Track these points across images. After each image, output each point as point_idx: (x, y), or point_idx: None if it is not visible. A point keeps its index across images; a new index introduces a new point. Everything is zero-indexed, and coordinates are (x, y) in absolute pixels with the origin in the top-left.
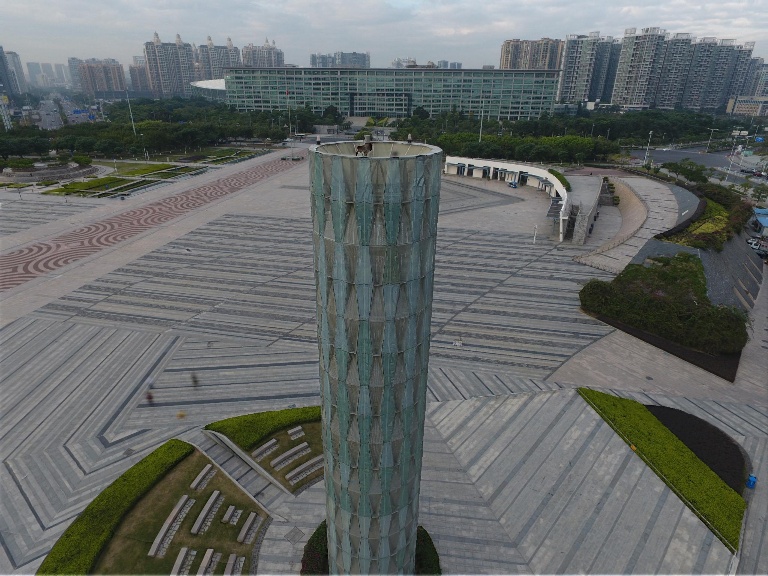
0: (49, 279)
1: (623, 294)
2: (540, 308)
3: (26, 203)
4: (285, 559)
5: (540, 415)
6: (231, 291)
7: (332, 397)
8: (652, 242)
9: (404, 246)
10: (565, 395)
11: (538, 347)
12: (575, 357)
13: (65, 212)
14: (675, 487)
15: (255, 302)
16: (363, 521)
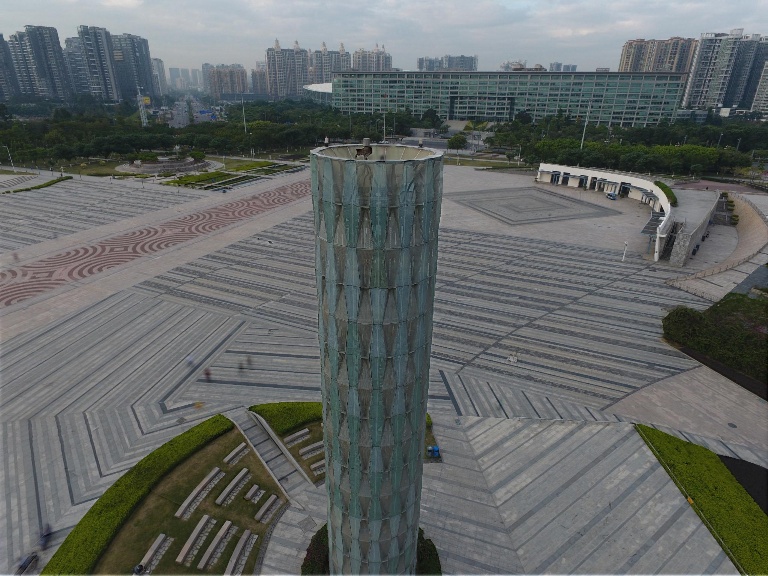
0: (150, 259)
1: (716, 326)
2: (614, 332)
3: (146, 191)
4: (294, 545)
5: (586, 447)
6: (300, 284)
7: (327, 394)
8: (763, 270)
9: (392, 251)
10: (620, 430)
11: (602, 374)
12: (644, 390)
13: (175, 201)
14: (733, 554)
15: None
16: (354, 521)
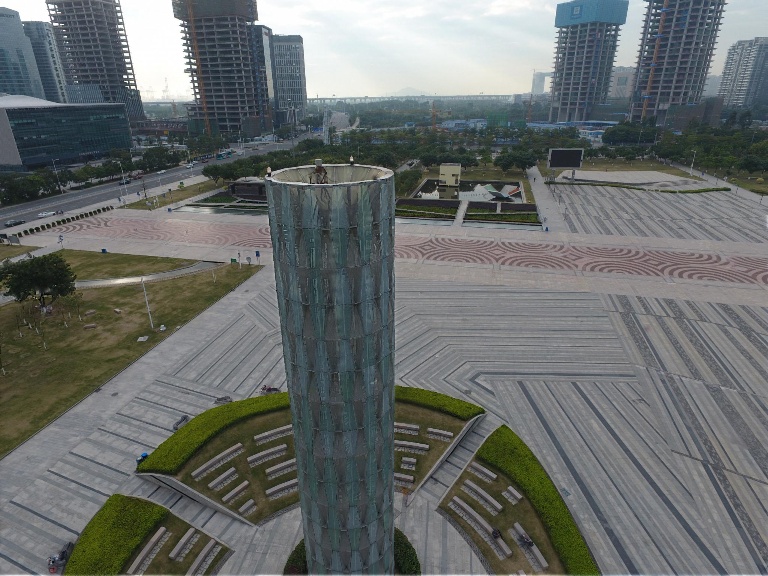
0: (662, 281)
1: None
2: None
3: None
4: None
5: None
6: None
7: None
8: None
9: None
10: None
11: None
12: None
13: None
14: None
15: None
16: None
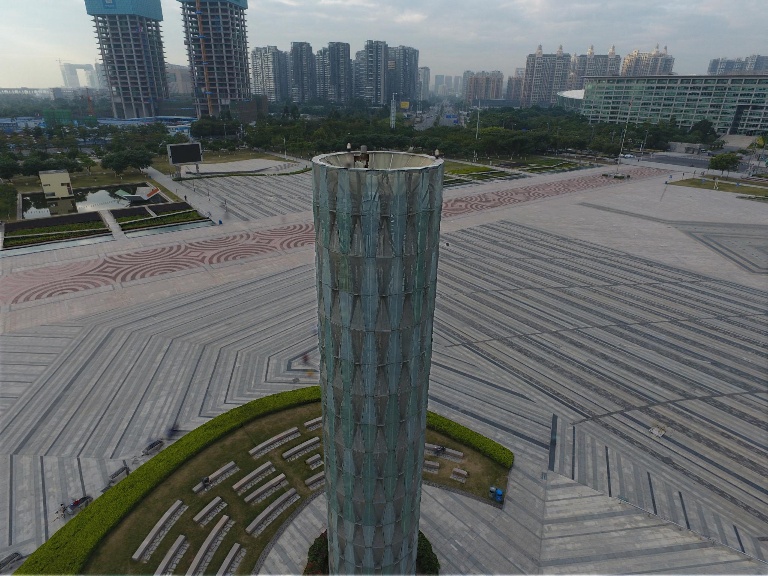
0: None
1: None
2: None
3: None
4: (323, 519)
5: (697, 572)
6: (454, 289)
7: None
8: None
9: (358, 258)
10: (765, 573)
11: None
12: None
13: None
14: None
15: (466, 305)
16: None
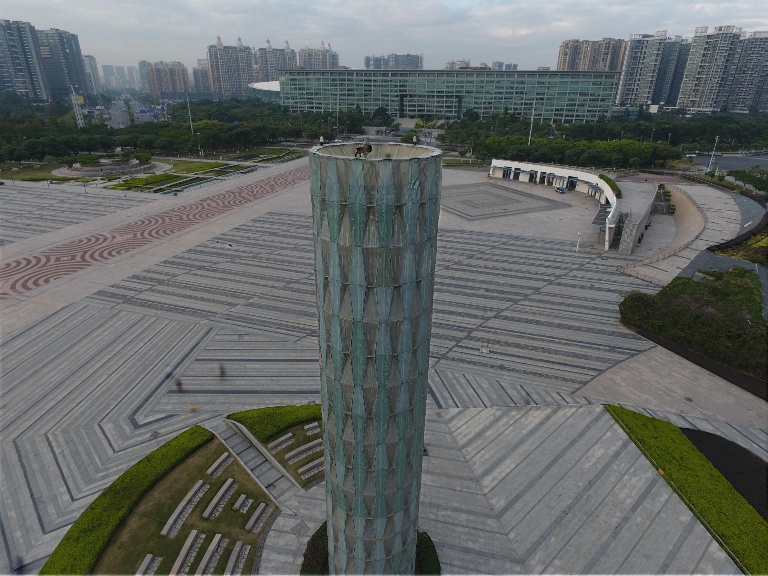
0: (102, 268)
1: (667, 308)
2: (576, 319)
3: (90, 196)
4: (289, 551)
5: (563, 430)
6: (266, 286)
7: (329, 395)
8: (704, 254)
9: (398, 248)
10: (592, 411)
11: (569, 359)
12: (608, 372)
13: (123, 206)
14: (703, 518)
15: (287, 298)
16: (358, 521)
